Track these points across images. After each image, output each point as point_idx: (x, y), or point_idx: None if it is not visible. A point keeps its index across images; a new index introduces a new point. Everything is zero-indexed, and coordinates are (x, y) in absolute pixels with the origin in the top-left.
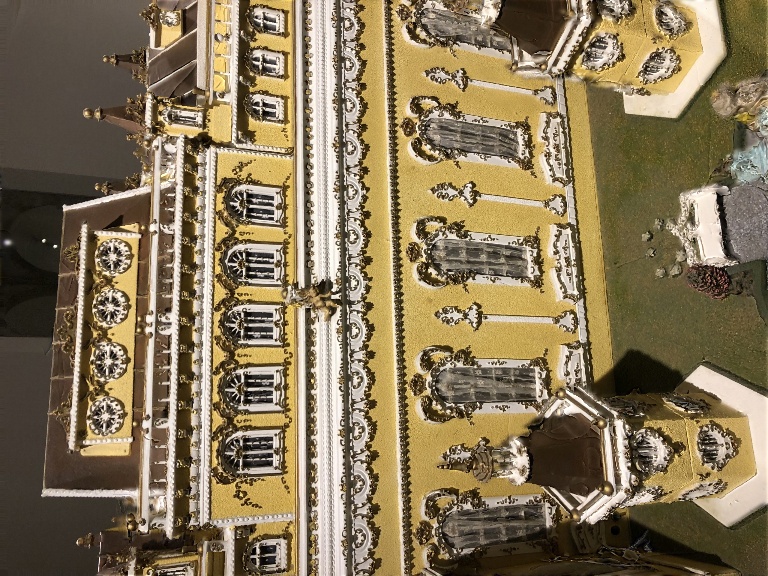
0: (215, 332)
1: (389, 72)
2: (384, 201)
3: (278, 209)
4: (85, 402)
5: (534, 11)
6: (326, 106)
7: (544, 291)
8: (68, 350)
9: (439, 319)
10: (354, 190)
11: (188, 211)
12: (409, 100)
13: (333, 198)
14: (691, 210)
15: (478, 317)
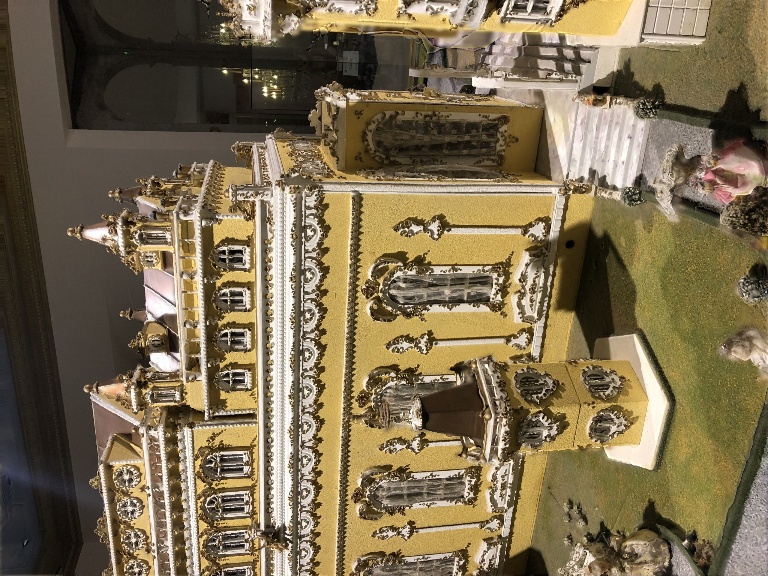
0: (201, 548)
1: (348, 355)
2: (335, 461)
3: (246, 465)
4: (122, 563)
5: (456, 430)
6: (284, 395)
7: (477, 504)
8: (104, 540)
9: (376, 536)
10: (307, 460)
11: (174, 471)
12: (366, 376)
13: (288, 471)
14: (583, 556)
15: (410, 533)
